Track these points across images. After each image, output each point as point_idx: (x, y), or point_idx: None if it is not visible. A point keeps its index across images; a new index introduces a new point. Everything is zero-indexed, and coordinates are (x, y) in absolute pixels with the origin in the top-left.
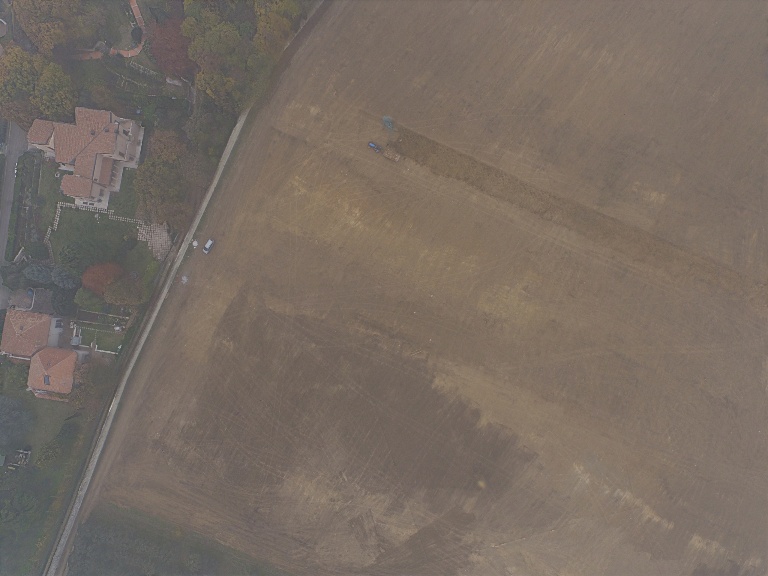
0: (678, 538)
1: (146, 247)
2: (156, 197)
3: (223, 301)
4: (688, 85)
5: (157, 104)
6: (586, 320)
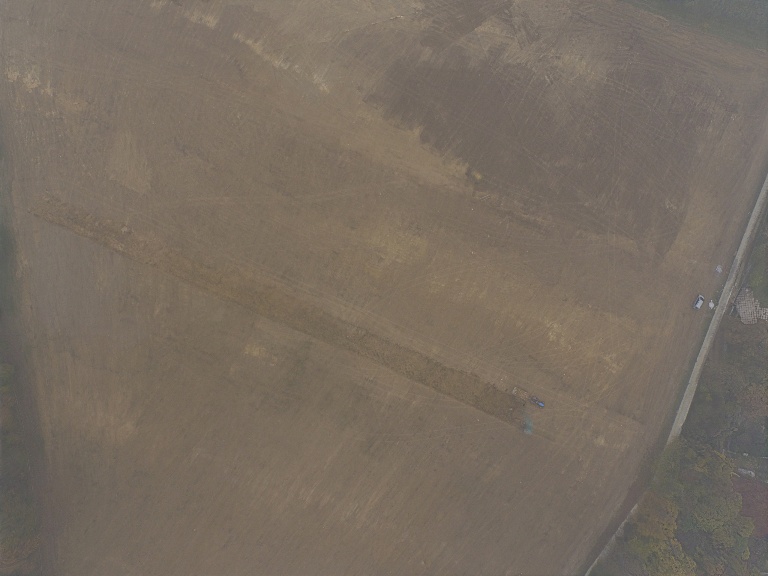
0: (229, 25)
1: (761, 302)
2: (767, 347)
3: (679, 248)
4: (223, 465)
5: (765, 448)
6: (321, 229)
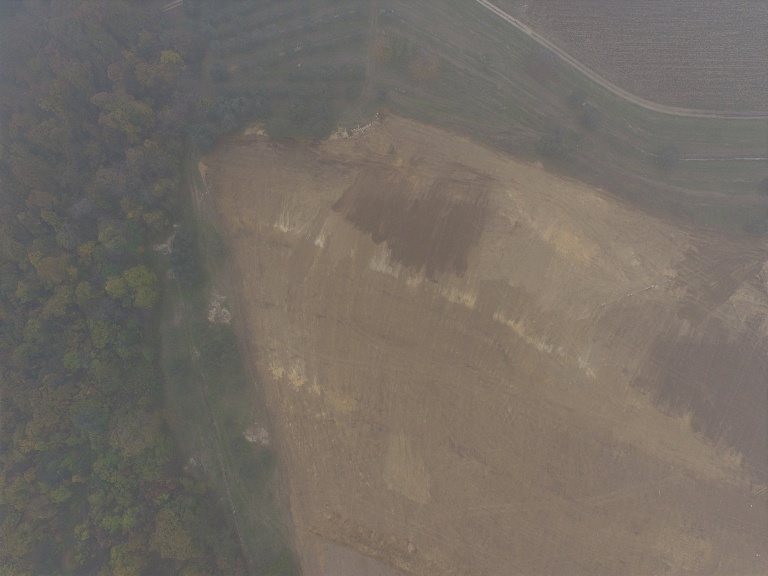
0: (487, 303)
1: None
2: None
3: None
4: None
5: None
6: (605, 535)
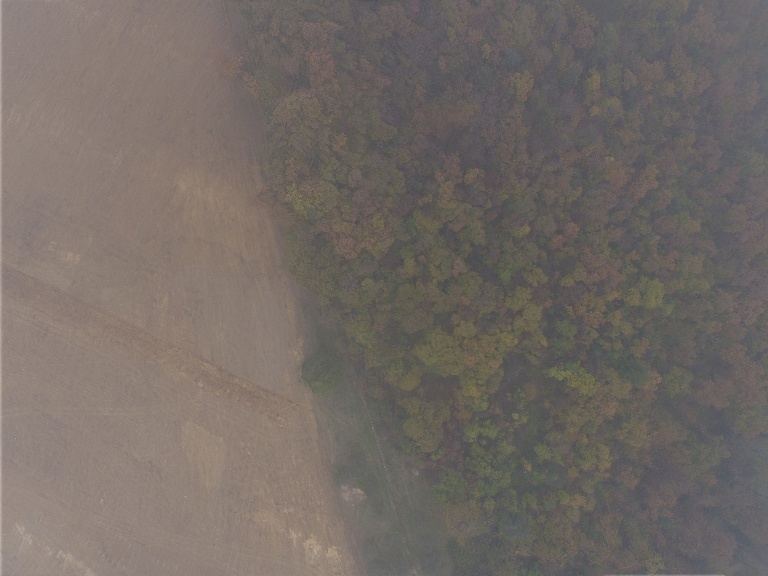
0: None
1: None
2: None
3: None
4: (92, 147)
5: None
6: (13, 379)
